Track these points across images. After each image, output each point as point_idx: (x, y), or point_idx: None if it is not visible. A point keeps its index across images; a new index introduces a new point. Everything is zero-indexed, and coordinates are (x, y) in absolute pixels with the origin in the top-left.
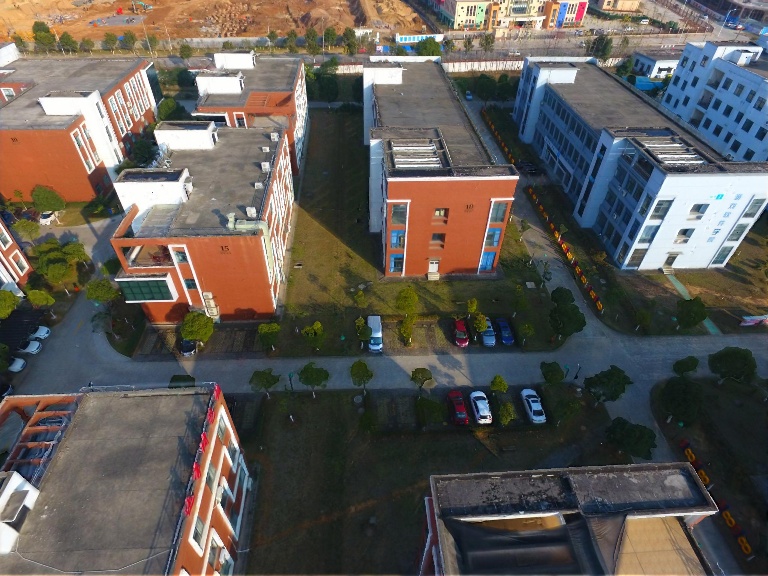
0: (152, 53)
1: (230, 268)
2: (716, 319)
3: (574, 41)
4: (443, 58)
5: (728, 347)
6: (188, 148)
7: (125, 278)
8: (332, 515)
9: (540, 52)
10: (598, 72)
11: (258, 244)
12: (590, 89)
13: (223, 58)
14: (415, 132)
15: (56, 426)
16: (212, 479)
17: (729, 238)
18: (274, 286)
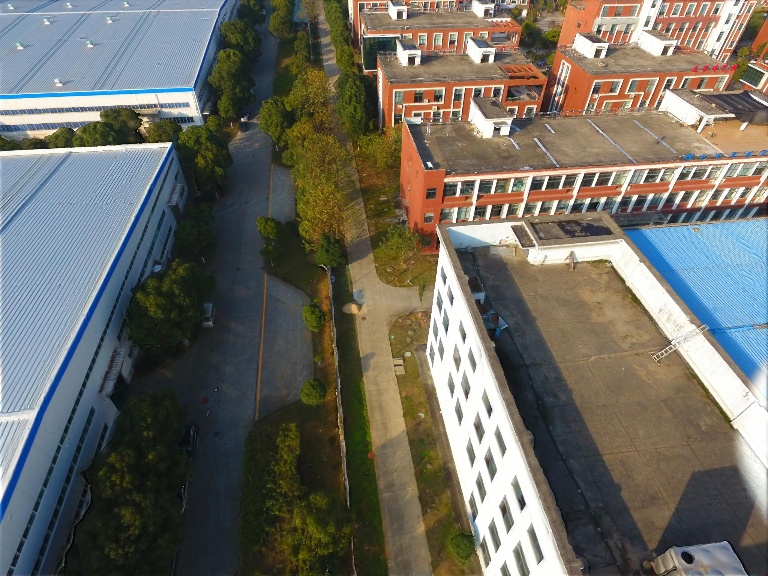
0: None
1: None
2: None
3: None
4: None
5: None
6: None
7: (753, 65)
8: None
9: None
10: None
11: None
12: None
13: None
14: None
15: None
16: None
17: None
18: None
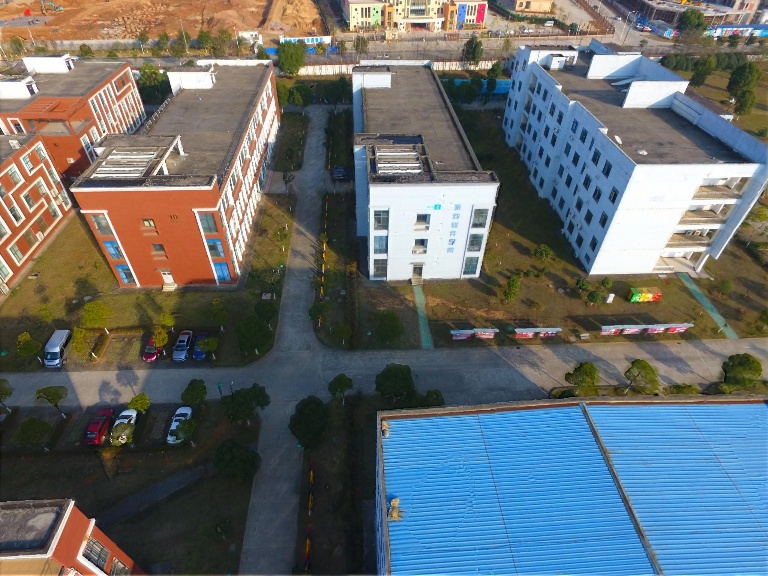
0: (6, 56)
1: None
2: (436, 332)
3: (444, 44)
4: (313, 61)
5: None
6: None
7: None
8: None
9: (410, 55)
10: (427, 76)
11: None
12: (401, 94)
13: (33, 62)
14: (151, 140)
15: None
16: None
17: (471, 248)
18: None
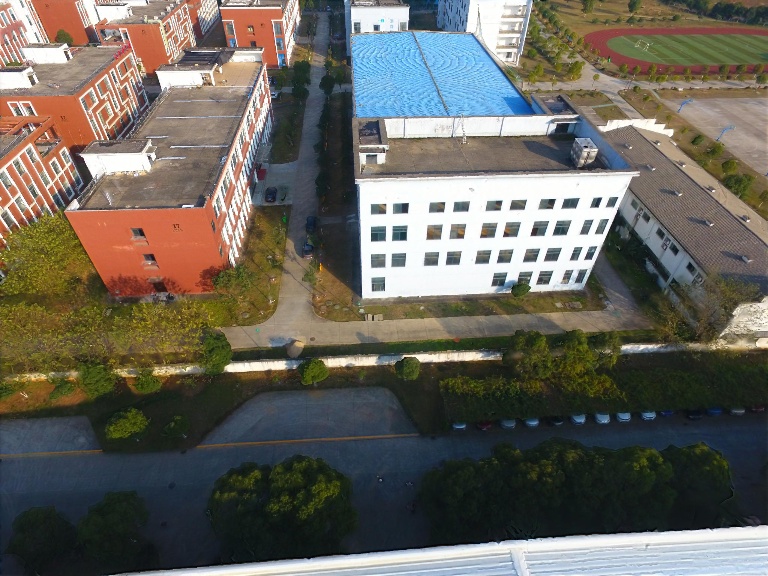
0: None
1: (147, 43)
2: None
3: None
4: None
5: None
6: (133, 5)
7: None
8: None
9: None
10: None
11: (158, 29)
12: None
13: None
14: None
15: None
16: None
17: None
18: None
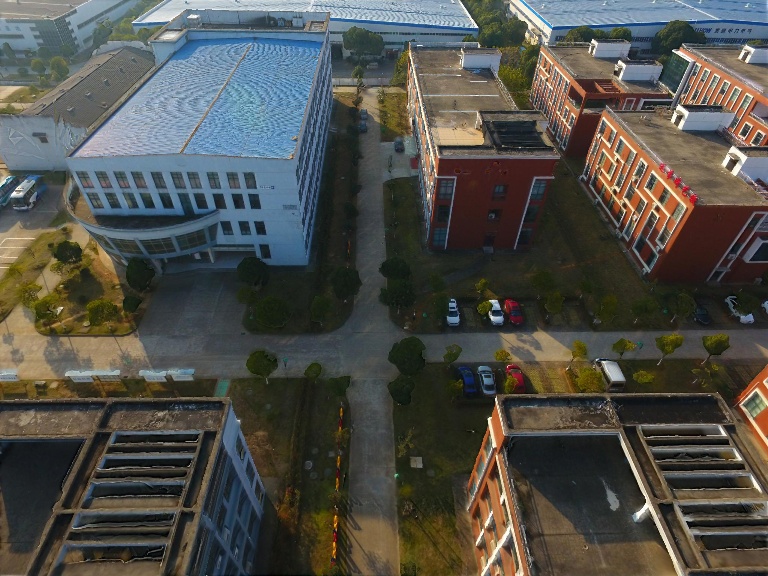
0: None
1: None
2: None
3: None
4: None
5: (276, 308)
6: None
7: None
8: (585, 264)
9: None
10: None
11: None
12: None
13: None
14: None
15: (767, 197)
16: (663, 203)
17: None
18: (765, 412)
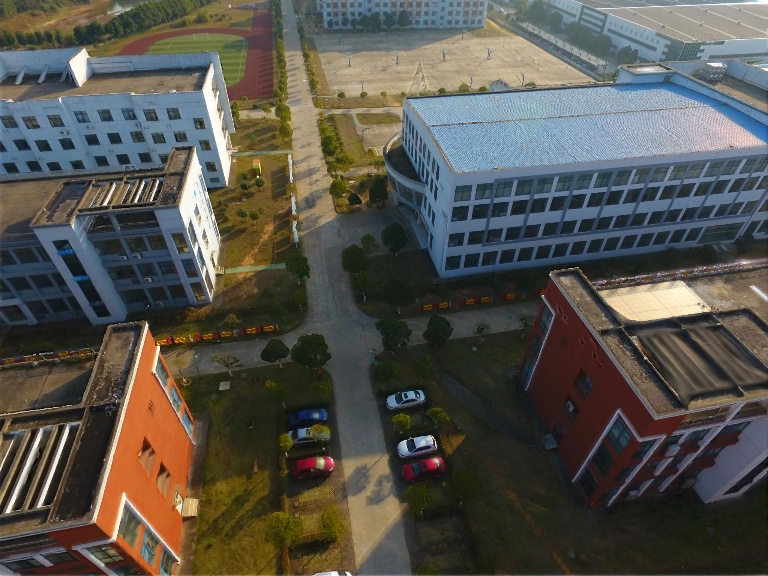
0: None
1: None
2: None
3: None
4: None
5: (348, 254)
6: None
7: None
8: None
9: None
10: None
11: None
12: None
13: None
14: None
15: None
16: None
17: None
18: None
